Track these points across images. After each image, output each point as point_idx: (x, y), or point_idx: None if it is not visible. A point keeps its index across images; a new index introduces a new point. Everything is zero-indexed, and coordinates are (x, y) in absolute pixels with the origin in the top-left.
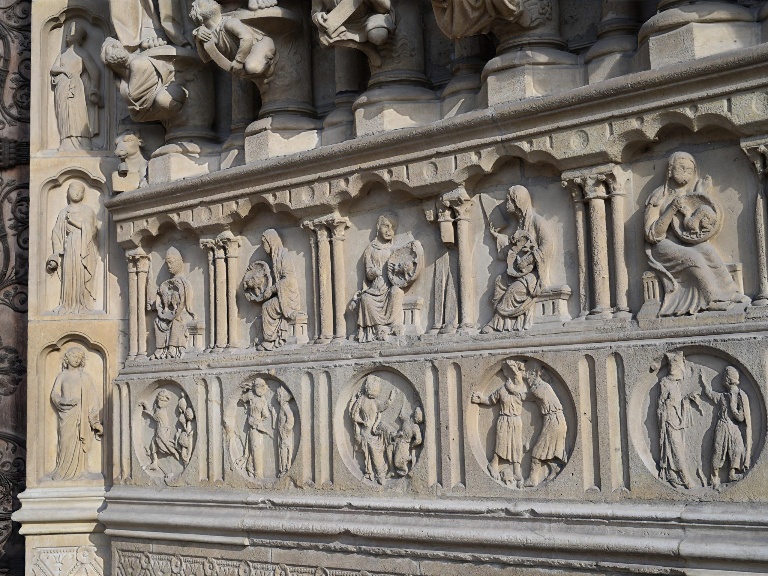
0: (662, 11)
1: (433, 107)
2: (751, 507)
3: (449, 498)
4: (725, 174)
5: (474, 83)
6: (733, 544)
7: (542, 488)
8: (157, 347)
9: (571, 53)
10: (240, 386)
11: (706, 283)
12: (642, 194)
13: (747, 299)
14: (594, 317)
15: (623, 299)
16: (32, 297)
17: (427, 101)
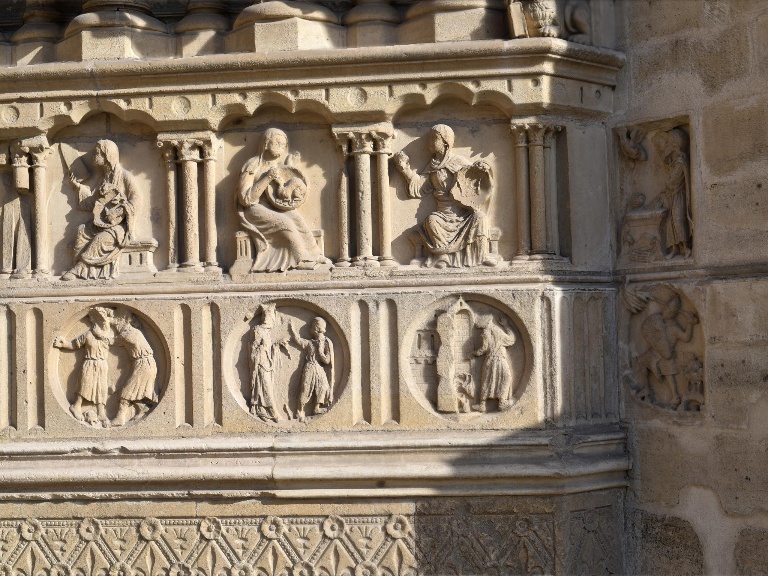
0: (266, 1)
1: (4, 49)
2: (335, 435)
3: (25, 440)
4: (312, 152)
5: (53, 32)
6: (321, 466)
7: (131, 427)
8: None
9: (161, 21)
10: None
11: (297, 245)
12: (233, 161)
13: (329, 261)
14: (187, 270)
15: (214, 255)
16: None
17: None
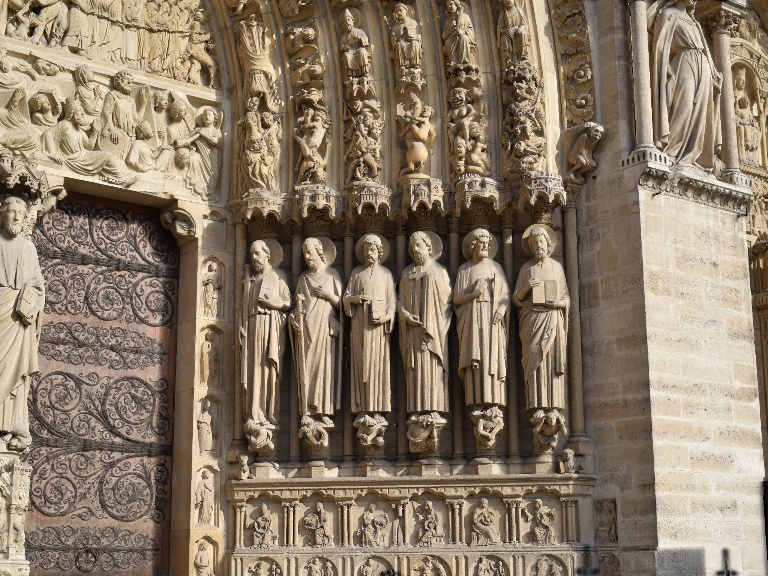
0: None
1: (393, 469)
2: None
3: None
4: (496, 506)
5: (409, 463)
6: None
7: None
8: (255, 544)
9: None
10: (307, 561)
11: (492, 537)
12: (470, 508)
13: (502, 542)
14: (456, 544)
15: (464, 539)
16: (192, 519)
17: (391, 466)
